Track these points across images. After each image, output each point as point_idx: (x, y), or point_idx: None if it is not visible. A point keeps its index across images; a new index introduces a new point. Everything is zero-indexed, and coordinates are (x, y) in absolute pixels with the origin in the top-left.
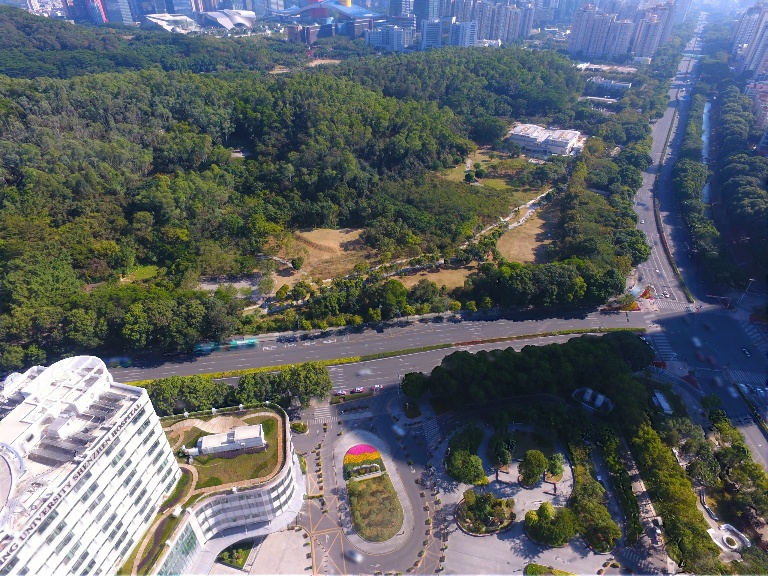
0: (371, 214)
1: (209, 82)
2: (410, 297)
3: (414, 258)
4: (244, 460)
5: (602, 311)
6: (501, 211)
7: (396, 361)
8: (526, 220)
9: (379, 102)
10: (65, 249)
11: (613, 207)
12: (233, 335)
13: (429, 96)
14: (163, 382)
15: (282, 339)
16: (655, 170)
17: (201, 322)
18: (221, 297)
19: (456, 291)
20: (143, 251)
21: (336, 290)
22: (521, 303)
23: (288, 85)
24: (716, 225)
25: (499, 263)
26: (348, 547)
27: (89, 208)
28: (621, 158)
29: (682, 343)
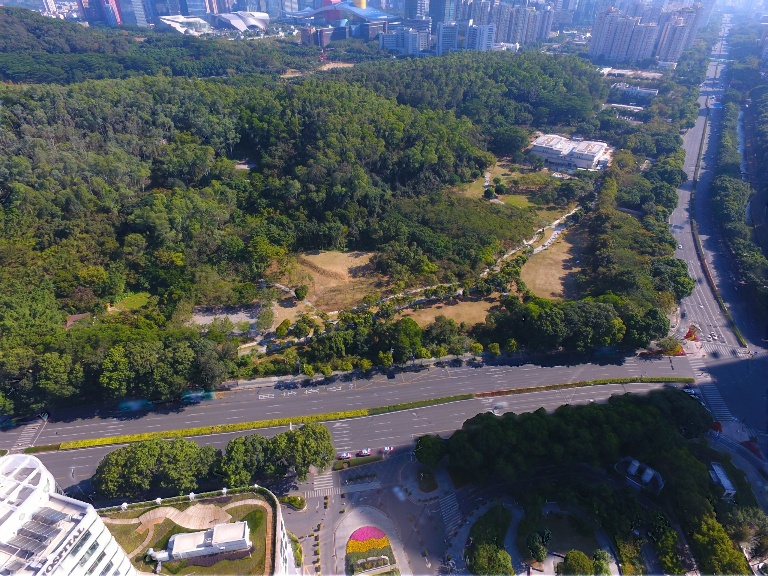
0: (383, 237)
1: (215, 89)
2: (425, 337)
3: (430, 289)
4: (223, 569)
5: (642, 355)
6: (524, 233)
7: (409, 415)
8: (552, 243)
9: (393, 111)
10: (48, 276)
11: (648, 231)
12: (226, 379)
13: (446, 105)
14: (139, 448)
15: (281, 385)
16: (689, 186)
17: (189, 368)
18: (213, 337)
19: (476, 329)
20: (134, 277)
21: (343, 327)
22: (550, 346)
23: (297, 93)
24: (762, 251)
25: (524, 296)
26: None
27: (78, 229)
28: (653, 173)
29: (737, 398)
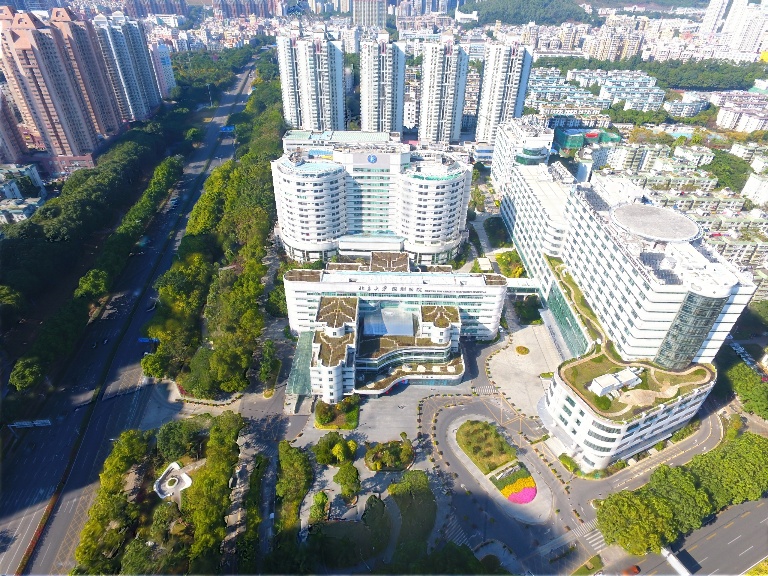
0: None
1: None
2: None
3: None
4: (592, 376)
5: None
6: None
7: None
8: None
9: None
10: None
11: None
12: None
13: None
14: None
15: None
16: None
17: None
18: None
19: None
20: None
21: None
22: None
23: None
24: None
25: None
26: (489, 415)
27: None
28: None
29: None
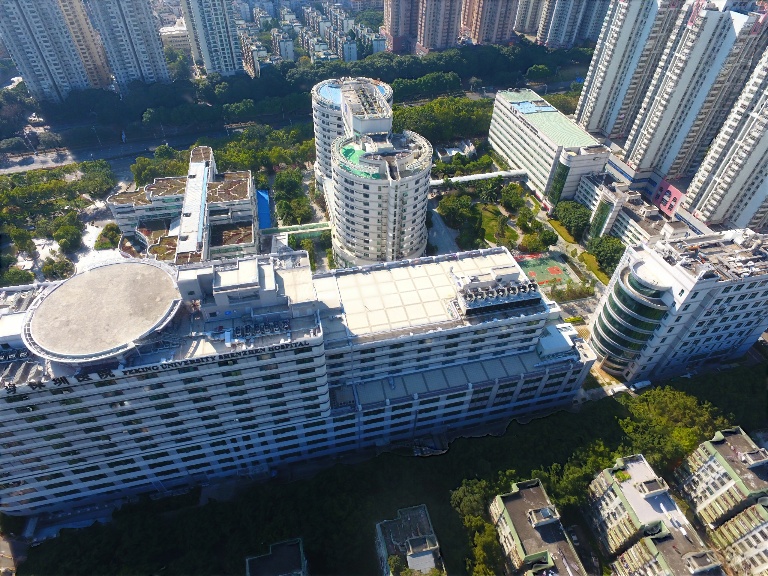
0: None
1: None
2: None
3: None
4: None
5: None
6: None
7: None
8: None
9: None
10: None
11: None
12: None
13: None
14: None
15: None
16: None
17: None
18: None
19: None
20: None
21: None
22: None
23: None
24: None
25: None
26: None
27: None
28: None
29: None
